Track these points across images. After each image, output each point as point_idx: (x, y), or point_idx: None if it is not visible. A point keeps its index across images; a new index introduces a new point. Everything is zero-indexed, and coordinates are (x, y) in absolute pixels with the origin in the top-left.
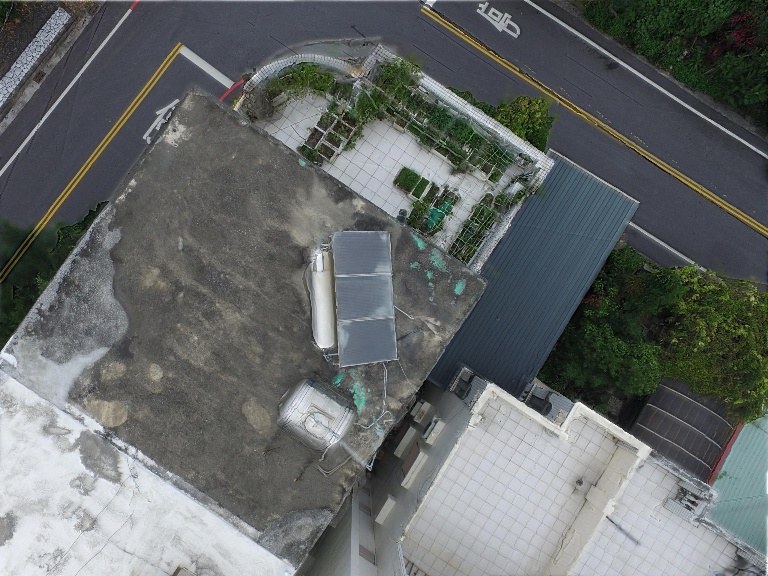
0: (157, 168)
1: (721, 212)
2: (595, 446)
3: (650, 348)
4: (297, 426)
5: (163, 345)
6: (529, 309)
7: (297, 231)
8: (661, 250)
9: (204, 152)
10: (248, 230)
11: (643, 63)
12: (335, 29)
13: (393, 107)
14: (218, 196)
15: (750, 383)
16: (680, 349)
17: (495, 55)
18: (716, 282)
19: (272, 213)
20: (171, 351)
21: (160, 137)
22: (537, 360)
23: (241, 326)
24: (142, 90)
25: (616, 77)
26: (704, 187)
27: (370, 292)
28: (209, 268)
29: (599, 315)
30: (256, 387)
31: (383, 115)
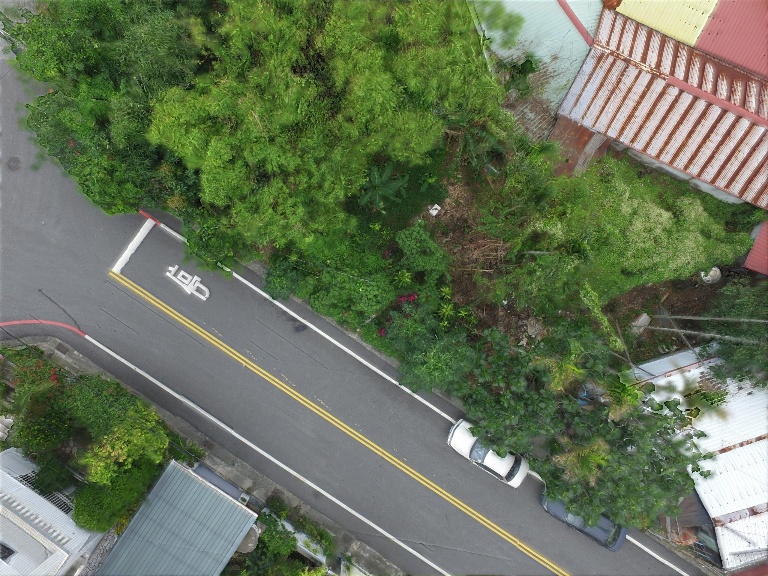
0: None
1: (401, 476)
2: None
3: None
4: None
5: None
6: None
7: None
8: (342, 512)
9: None
10: None
11: (331, 325)
12: (22, 293)
13: None
14: None
15: None
16: None
17: (182, 318)
18: None
19: None
20: None
21: None
22: None
23: None
24: None
25: (303, 340)
26: (385, 451)
27: None
28: None
29: None
30: None
31: None
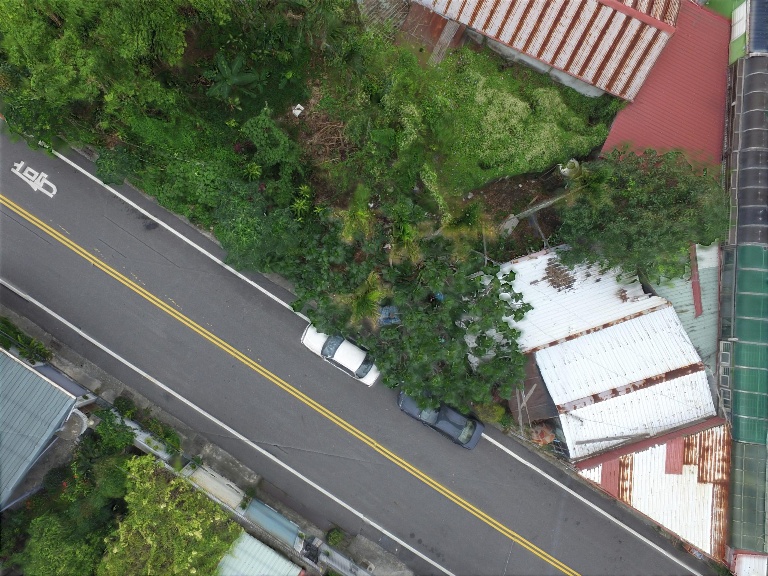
0: None
1: (255, 376)
2: None
3: (71, 551)
4: None
5: None
6: None
7: None
8: (194, 414)
9: None
10: None
11: (184, 223)
12: None
13: None
14: None
15: None
16: None
17: (28, 215)
18: (151, 480)
19: None
20: None
21: None
22: None
23: None
24: None
25: (154, 238)
26: (238, 351)
27: None
28: None
29: None
30: None
31: None
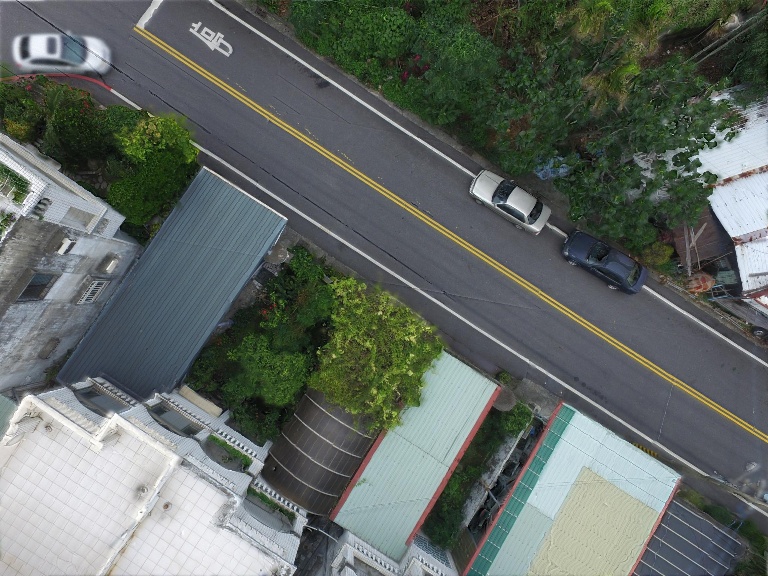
0: None
1: (424, 227)
2: (160, 455)
3: (289, 360)
4: None
5: None
6: (172, 321)
7: None
8: (366, 263)
9: None
10: None
11: (353, 82)
12: (47, 46)
13: None
14: None
15: (364, 394)
16: (322, 361)
17: (206, 73)
18: (360, 296)
19: None
20: None
21: None
22: (175, 370)
23: None
24: None
25: (325, 96)
26: (408, 203)
27: None
28: None
29: None
30: None
31: None
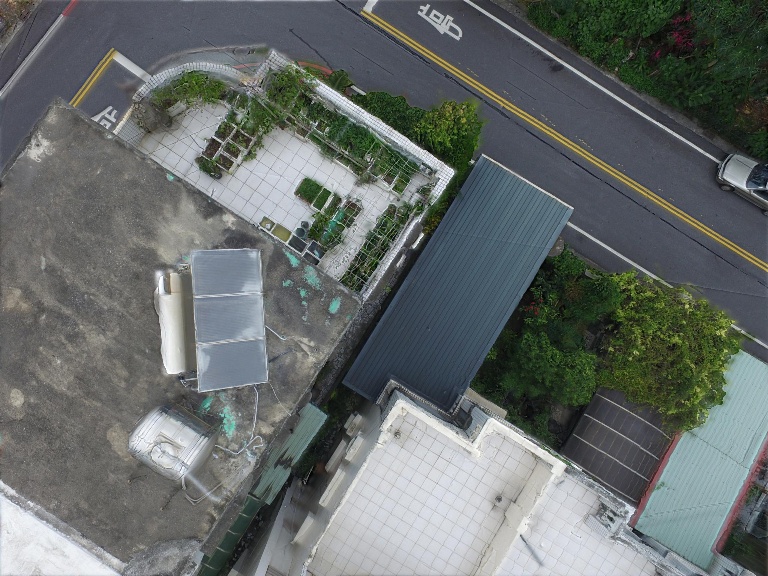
0: (19, 184)
1: (668, 216)
2: (514, 461)
3: (585, 357)
4: (144, 456)
5: (24, 369)
6: (460, 319)
7: (164, 249)
8: (607, 255)
9: (68, 167)
10: (113, 248)
11: (588, 65)
12: (273, 33)
13: (294, 116)
14: (82, 213)
15: (683, 393)
16: (616, 358)
17: (437, 58)
18: (652, 289)
19: (138, 230)
20: (33, 375)
21: (22, 152)
22: (468, 371)
23: (106, 349)
24: (74, 97)
25: (560, 79)
26: (650, 191)
27: (236, 313)
28: (72, 288)
29: (538, 323)
30: (121, 412)
31: (285, 124)
